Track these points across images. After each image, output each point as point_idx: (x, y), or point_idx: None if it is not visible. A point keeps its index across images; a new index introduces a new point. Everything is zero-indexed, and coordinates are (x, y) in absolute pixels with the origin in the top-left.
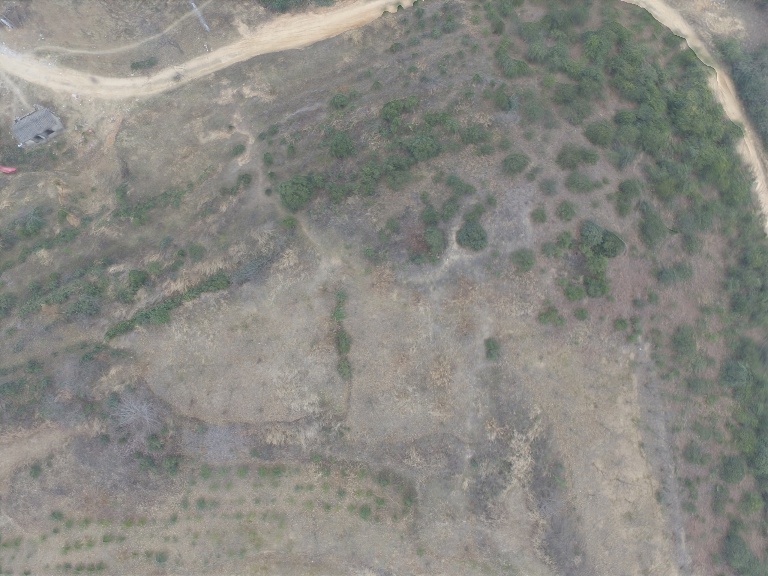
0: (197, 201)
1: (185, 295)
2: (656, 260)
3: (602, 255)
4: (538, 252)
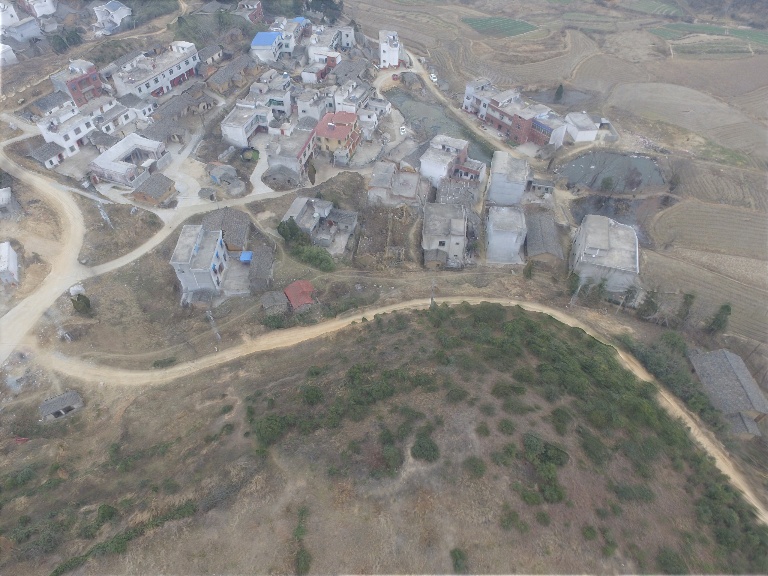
0: (182, 448)
1: (148, 524)
2: (607, 475)
3: (548, 462)
4: (488, 462)
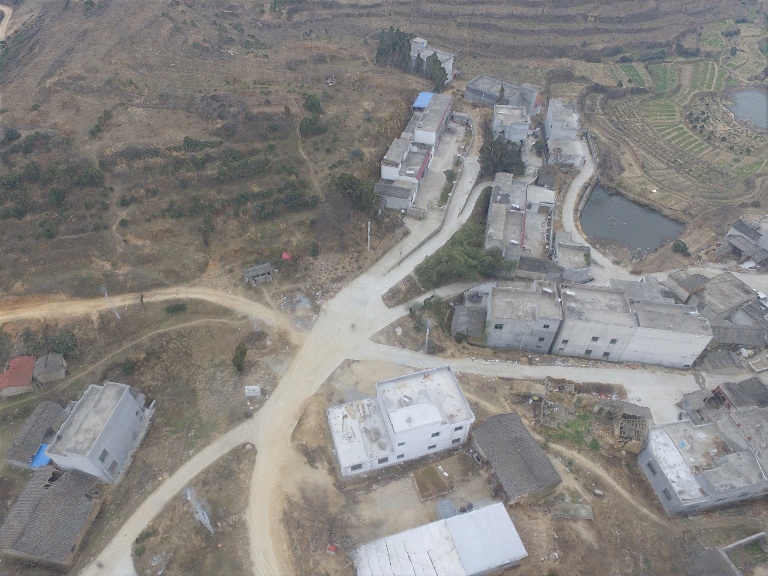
0: (159, 201)
1: (172, 147)
2: None
3: None
4: None
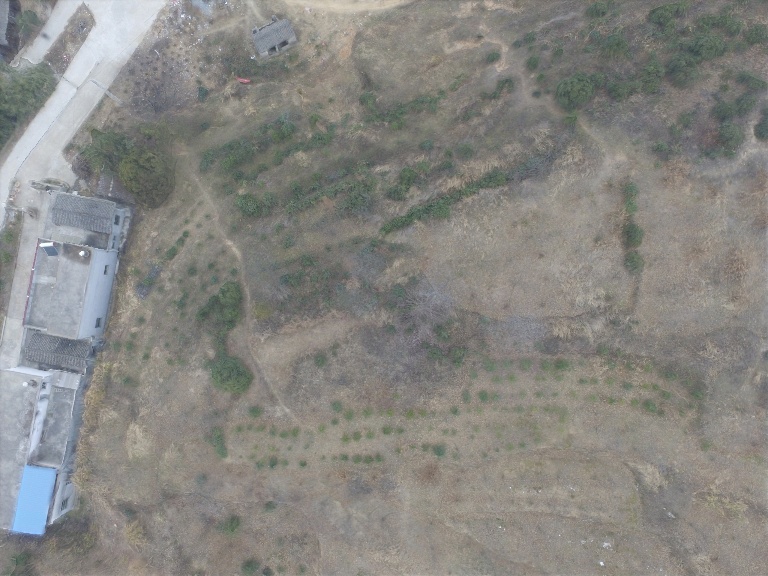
0: (455, 106)
1: (465, 190)
2: None
3: None
4: None
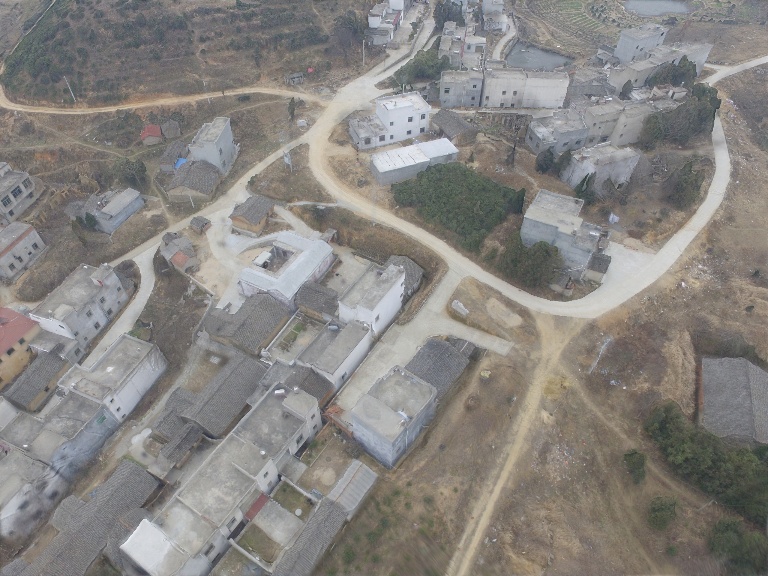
0: (224, 40)
1: (229, 7)
2: None
3: None
4: None
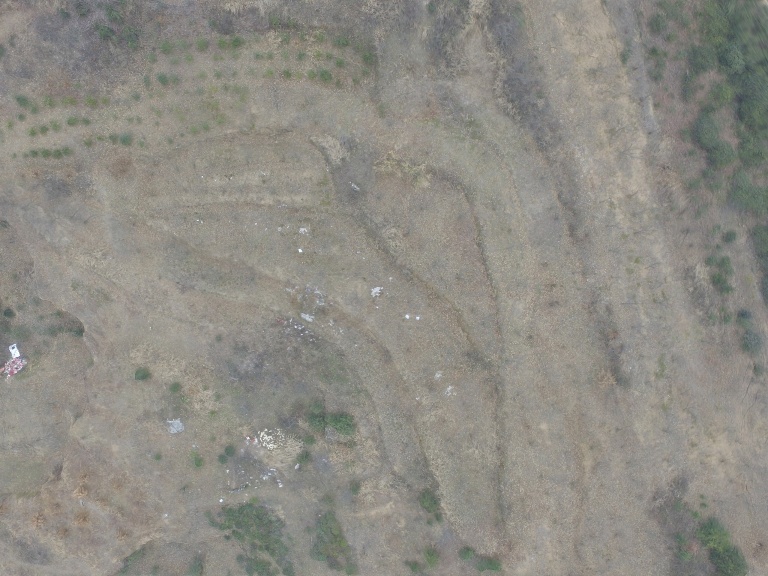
0: None
1: None
2: None
3: None
4: None
